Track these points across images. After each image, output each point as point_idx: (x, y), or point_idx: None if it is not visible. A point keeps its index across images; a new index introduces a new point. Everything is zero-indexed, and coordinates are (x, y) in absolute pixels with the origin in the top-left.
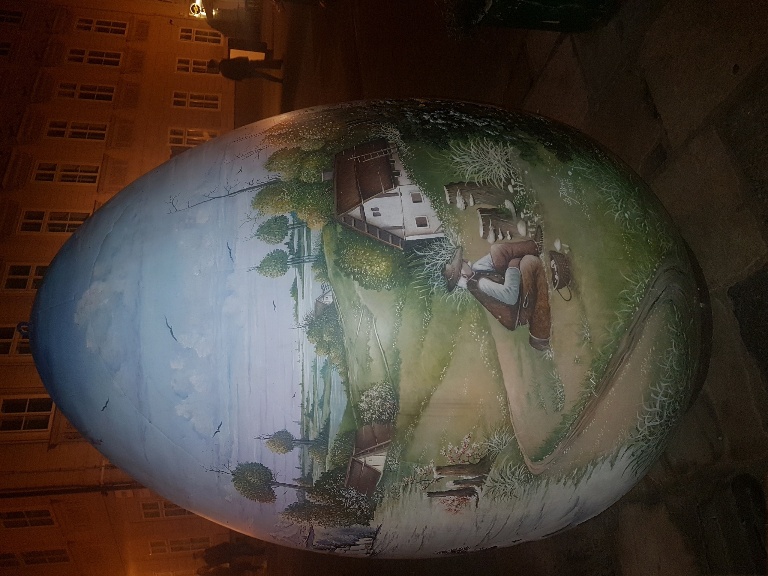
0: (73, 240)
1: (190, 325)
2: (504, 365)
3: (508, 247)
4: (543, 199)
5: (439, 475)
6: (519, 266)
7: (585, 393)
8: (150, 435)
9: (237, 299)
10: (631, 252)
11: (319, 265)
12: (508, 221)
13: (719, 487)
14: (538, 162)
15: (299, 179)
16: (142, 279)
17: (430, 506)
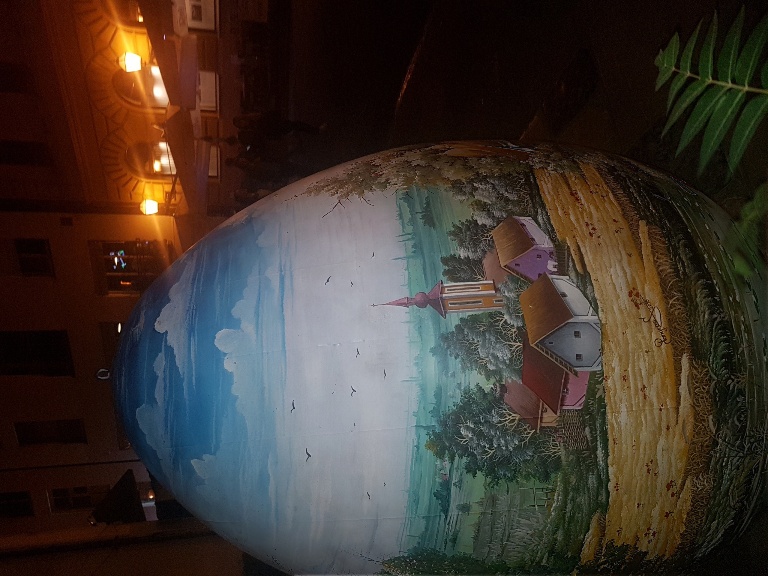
0: (161, 471)
1: None
2: None
3: None
4: None
5: None
6: None
7: None
8: None
9: None
10: None
11: None
12: None
13: None
14: None
15: None
16: None
17: None
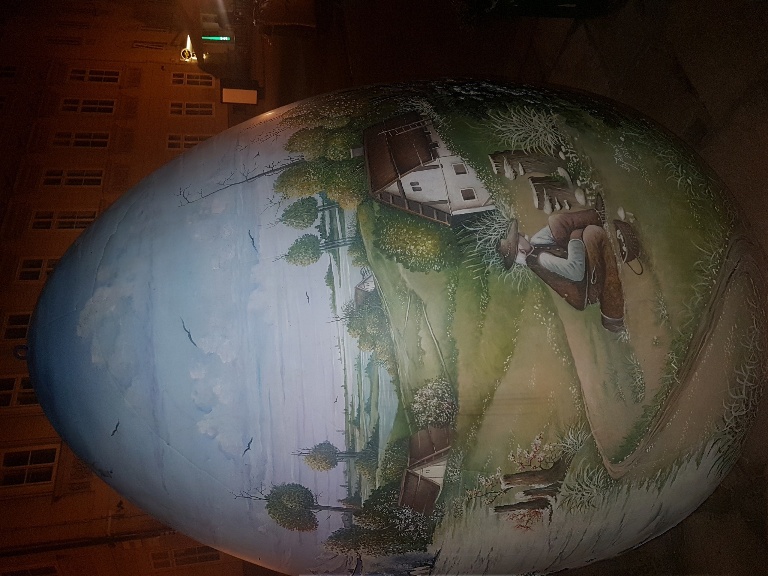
0: (72, 248)
1: (211, 327)
2: (575, 351)
3: (567, 217)
4: (599, 165)
5: (507, 485)
6: (582, 238)
7: (667, 380)
8: (169, 460)
9: (264, 293)
10: (700, 220)
11: (356, 248)
12: (564, 189)
13: None
14: (586, 128)
15: (325, 157)
16: (153, 279)
17: (497, 523)
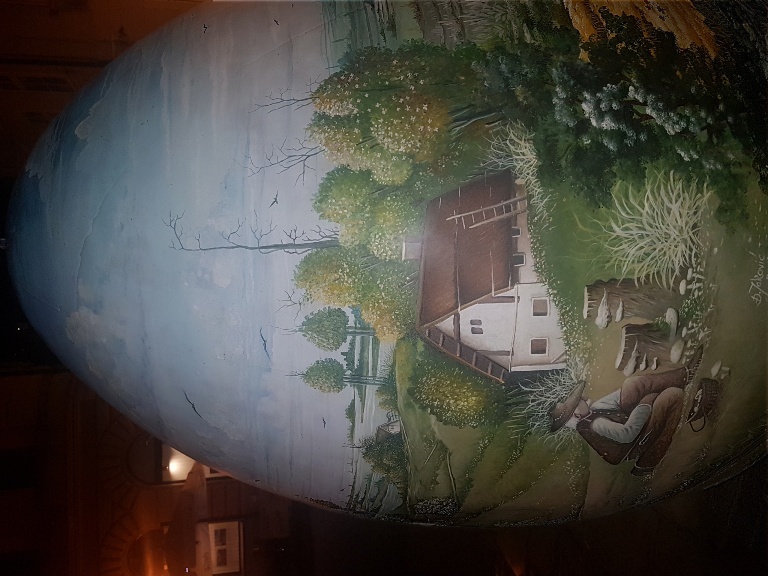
0: (37, 201)
1: (217, 410)
2: (592, 489)
3: (648, 380)
4: (723, 301)
5: None
6: (653, 402)
7: (671, 491)
8: None
9: (276, 403)
10: None
11: (387, 391)
12: (661, 343)
13: None
14: (740, 224)
15: (367, 249)
16: (147, 337)
17: None
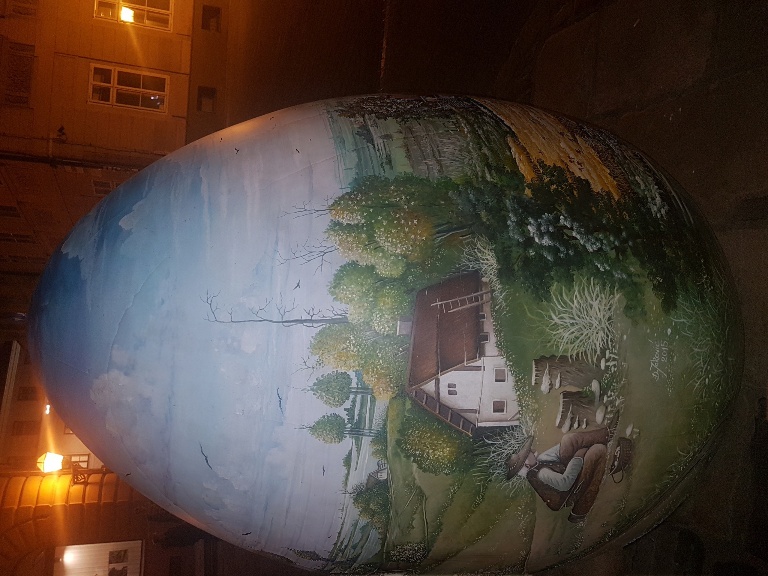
0: (78, 279)
1: (228, 461)
2: (537, 534)
3: (580, 437)
4: (632, 376)
5: None
6: (584, 456)
7: (599, 541)
8: (174, 508)
9: (283, 453)
10: (695, 424)
11: (379, 442)
12: (589, 407)
13: (668, 525)
14: (641, 318)
15: (370, 325)
16: (173, 396)
17: None
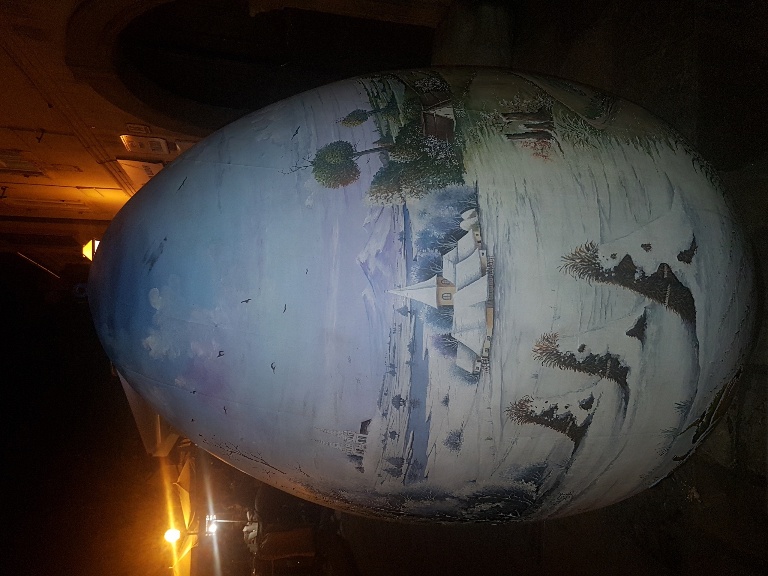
0: None
1: None
2: None
3: None
4: None
5: (508, 120)
6: None
7: None
8: (227, 175)
9: None
10: None
11: None
12: None
13: None
14: None
15: None
16: None
17: (515, 150)
